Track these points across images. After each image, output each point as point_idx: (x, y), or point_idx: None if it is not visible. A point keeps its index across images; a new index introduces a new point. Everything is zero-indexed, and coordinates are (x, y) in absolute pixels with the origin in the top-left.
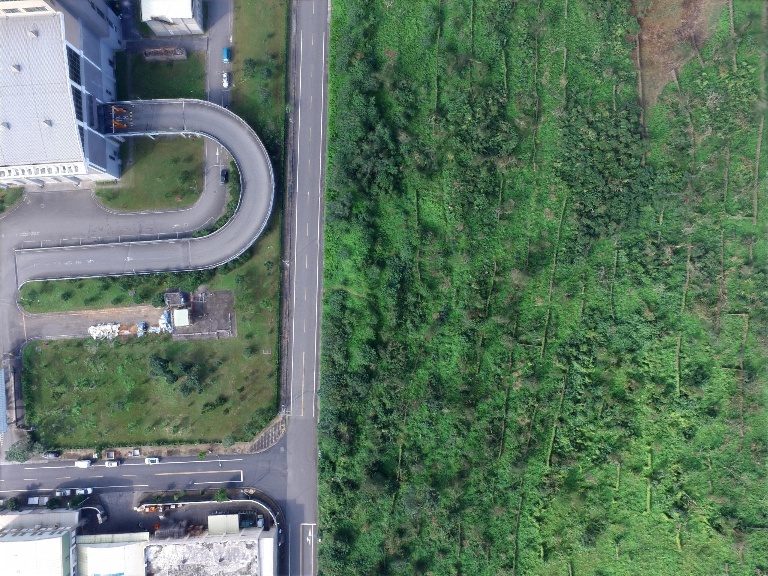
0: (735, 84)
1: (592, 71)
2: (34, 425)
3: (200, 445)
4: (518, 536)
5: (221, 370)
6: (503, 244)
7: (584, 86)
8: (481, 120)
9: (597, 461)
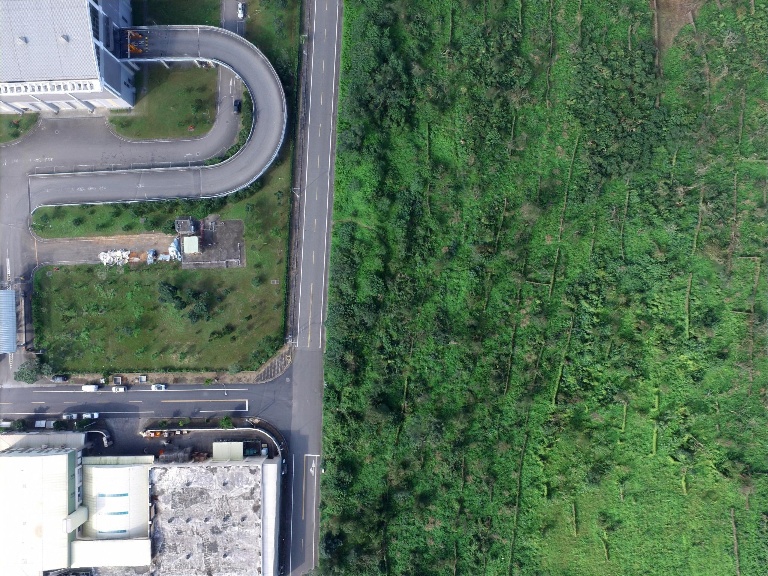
0: (752, 26)
1: (608, 9)
2: (43, 348)
3: (206, 373)
4: (522, 474)
5: (229, 299)
6: (514, 181)
7: (599, 25)
8: (495, 54)
9: (603, 401)
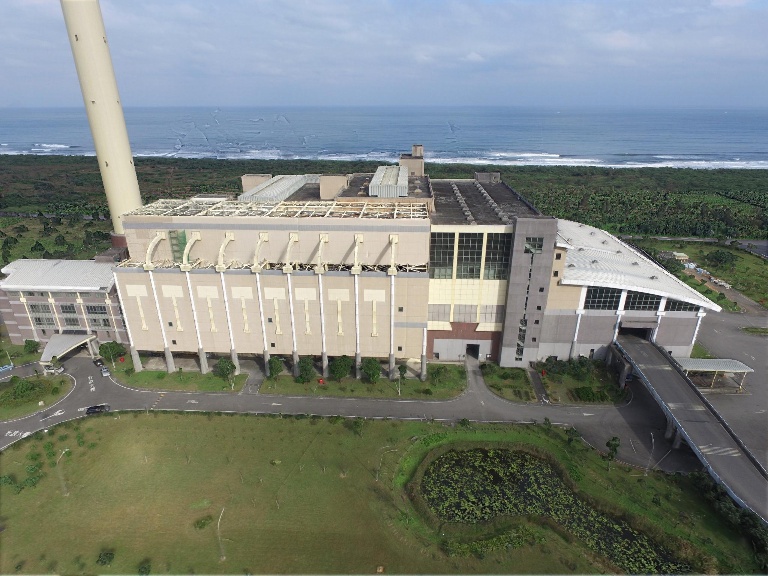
0: None
1: None
2: None
3: None
4: None
5: None
6: None
7: None
8: None
9: None
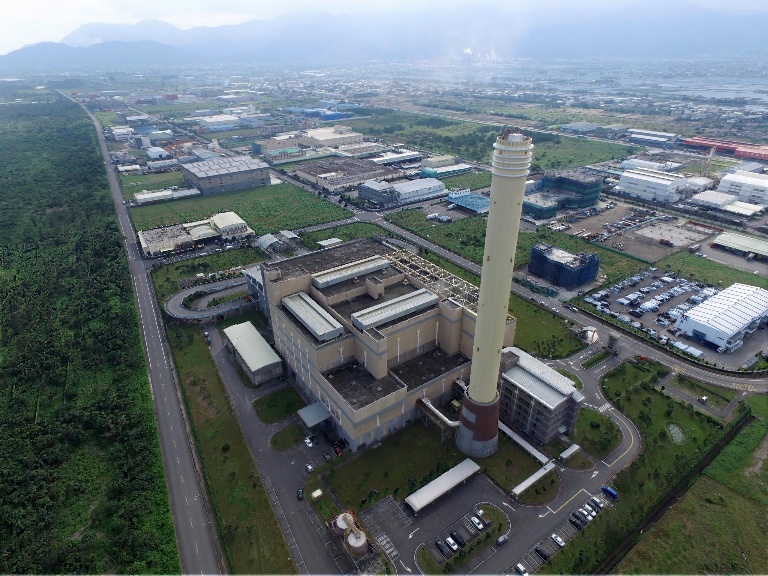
0: None
1: None
2: (252, 249)
3: None
4: None
5: None
6: None
7: None
8: None
9: None
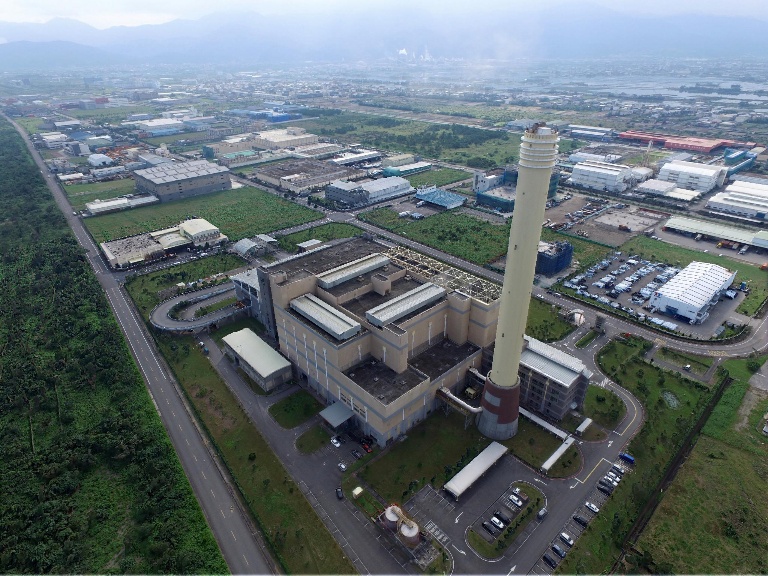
0: None
1: None
2: (229, 255)
3: None
4: None
5: None
6: None
7: None
8: None
9: None
